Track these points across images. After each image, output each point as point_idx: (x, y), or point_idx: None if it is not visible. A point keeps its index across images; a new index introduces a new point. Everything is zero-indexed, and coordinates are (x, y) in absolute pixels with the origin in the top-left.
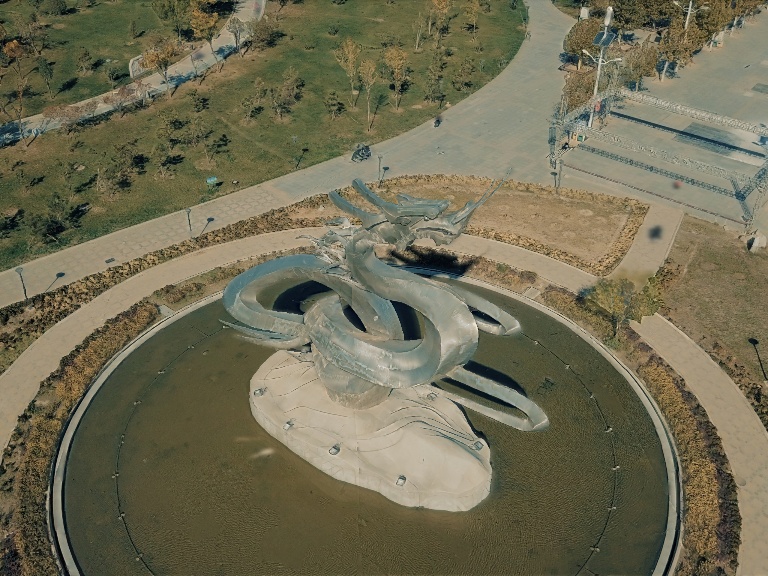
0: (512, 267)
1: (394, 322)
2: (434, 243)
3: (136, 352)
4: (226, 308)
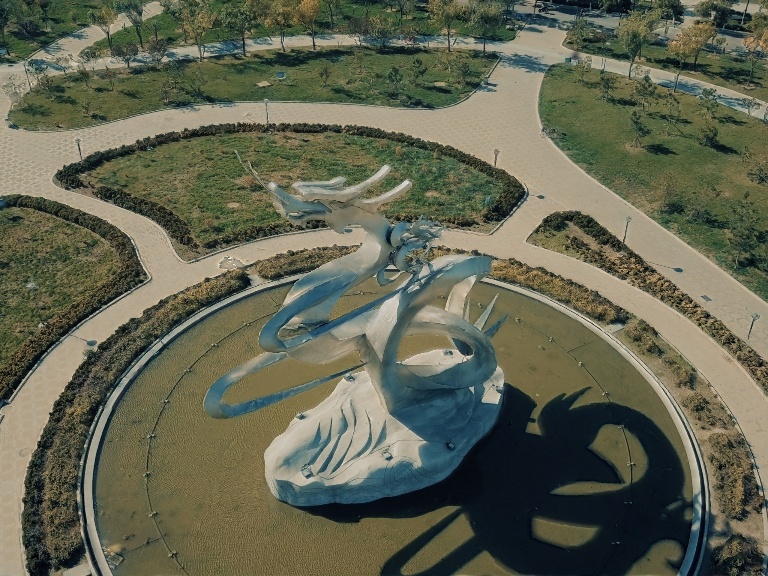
0: None
1: (382, 334)
2: None
3: (550, 308)
4: None
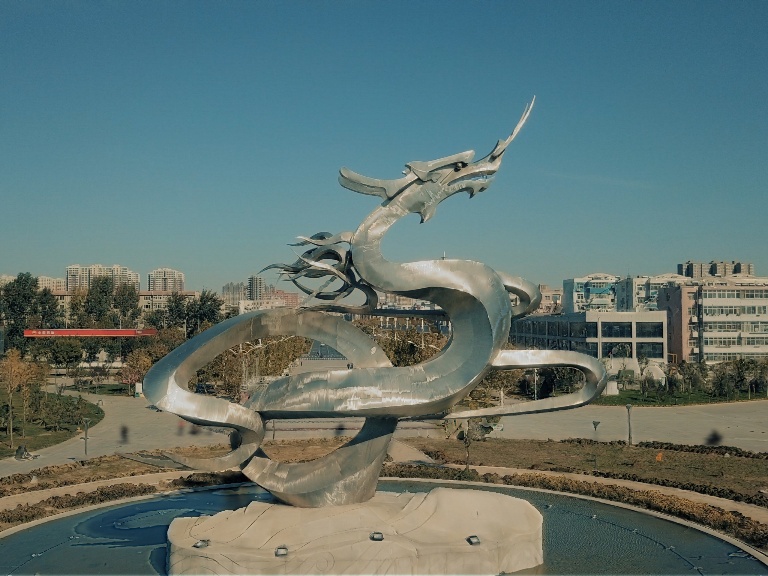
0: None
1: None
2: None
3: None
4: (154, 403)
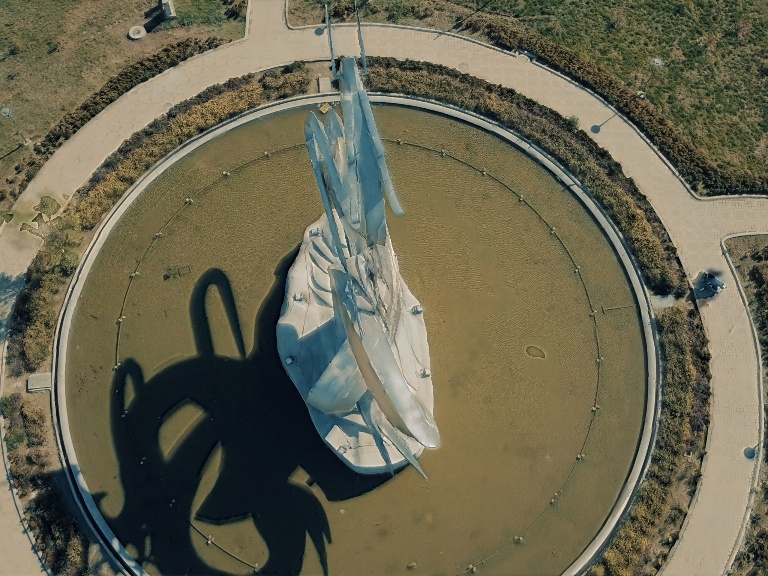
0: (5, 433)
1: None
2: (19, 553)
3: None
4: None
